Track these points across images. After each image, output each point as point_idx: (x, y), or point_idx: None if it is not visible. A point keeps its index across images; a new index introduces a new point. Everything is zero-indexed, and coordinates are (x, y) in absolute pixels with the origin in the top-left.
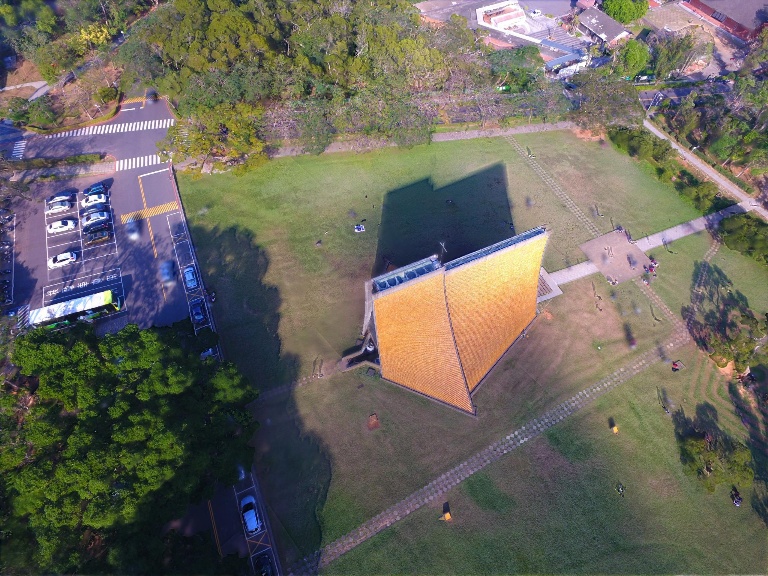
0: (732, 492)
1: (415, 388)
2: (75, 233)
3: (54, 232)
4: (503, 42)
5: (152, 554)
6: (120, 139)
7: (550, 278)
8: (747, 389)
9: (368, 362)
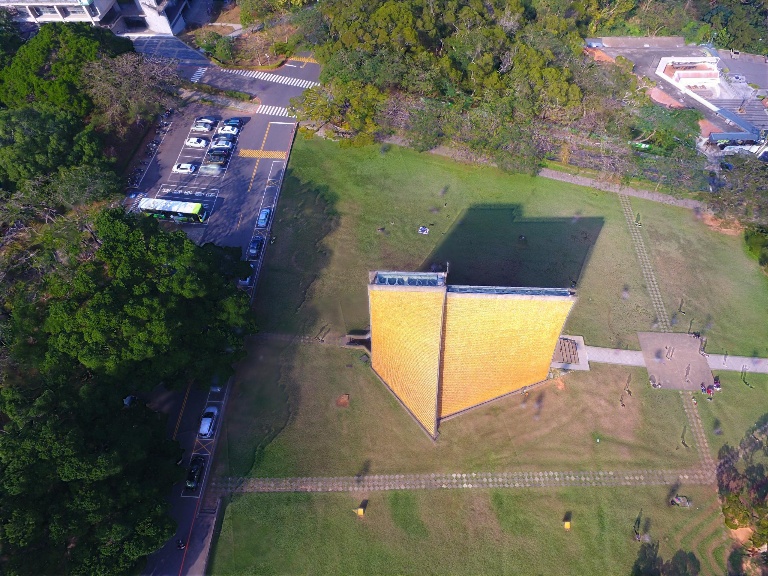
0: None
1: (394, 389)
2: (203, 151)
3: (189, 145)
4: (673, 99)
5: (110, 404)
6: (272, 88)
7: (584, 350)
8: (754, 567)
9: (366, 348)
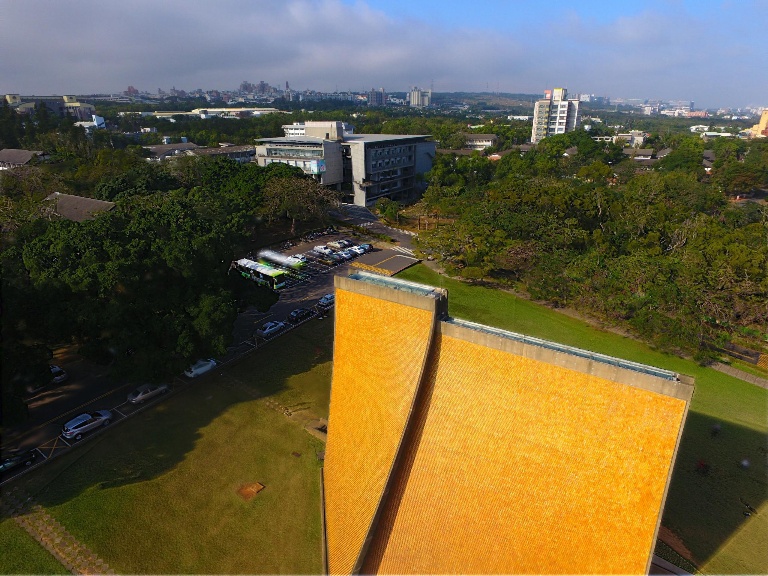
0: None
1: (327, 509)
2: (324, 256)
3: (317, 250)
4: None
5: (1, 305)
6: None
7: None
8: None
9: None
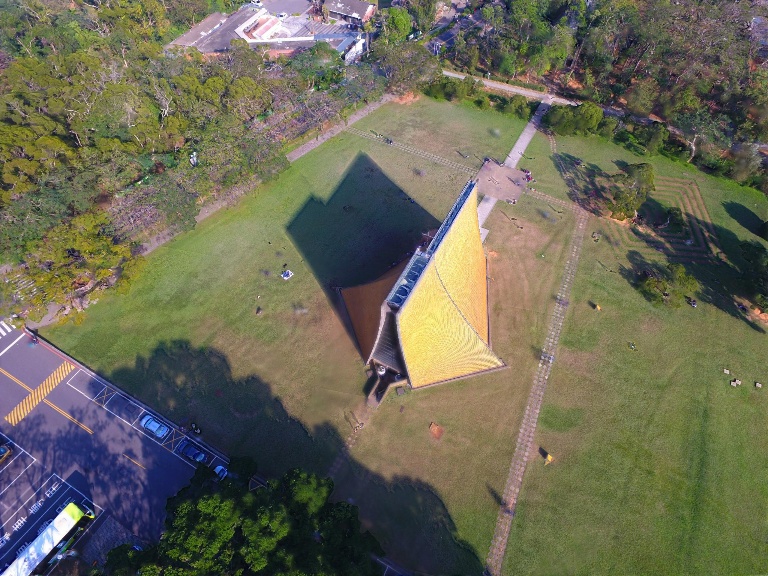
0: (686, 300)
1: (446, 378)
2: None
3: None
4: (282, 50)
5: None
6: None
7: None
8: (642, 226)
9: (393, 384)
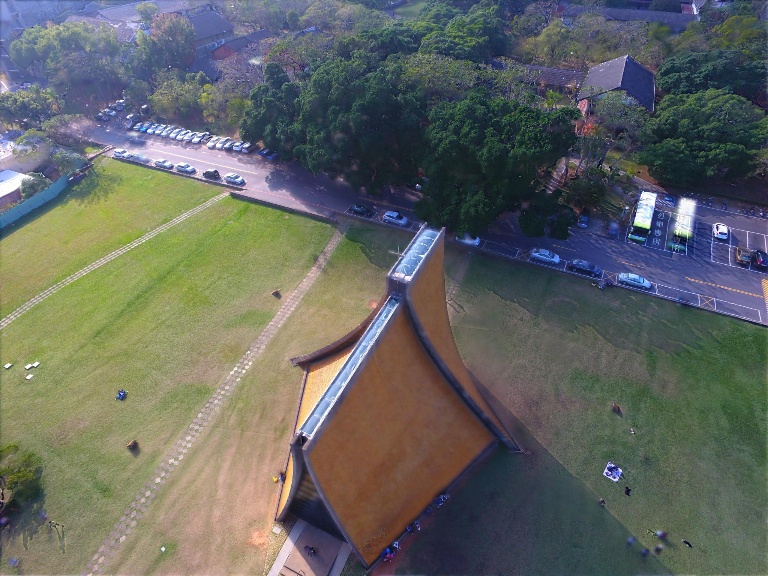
0: None
1: None
2: (763, 249)
3: None
4: None
5: (403, 133)
6: None
7: None
8: None
9: None
